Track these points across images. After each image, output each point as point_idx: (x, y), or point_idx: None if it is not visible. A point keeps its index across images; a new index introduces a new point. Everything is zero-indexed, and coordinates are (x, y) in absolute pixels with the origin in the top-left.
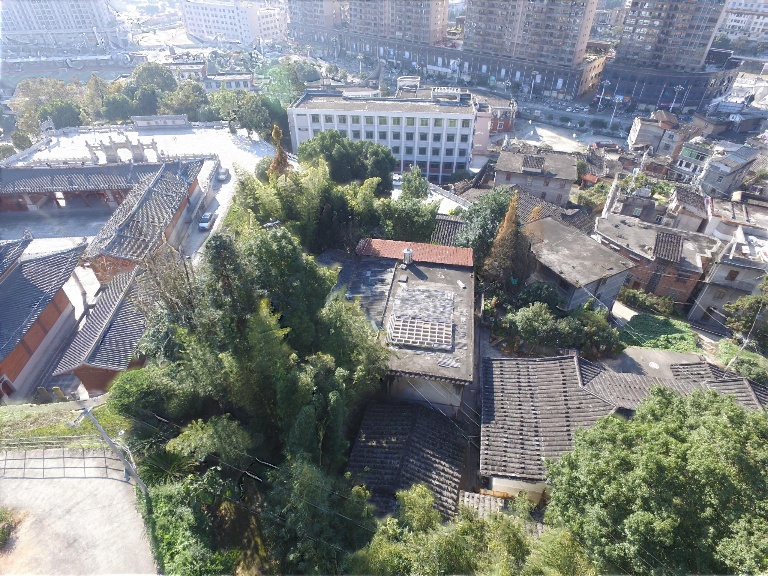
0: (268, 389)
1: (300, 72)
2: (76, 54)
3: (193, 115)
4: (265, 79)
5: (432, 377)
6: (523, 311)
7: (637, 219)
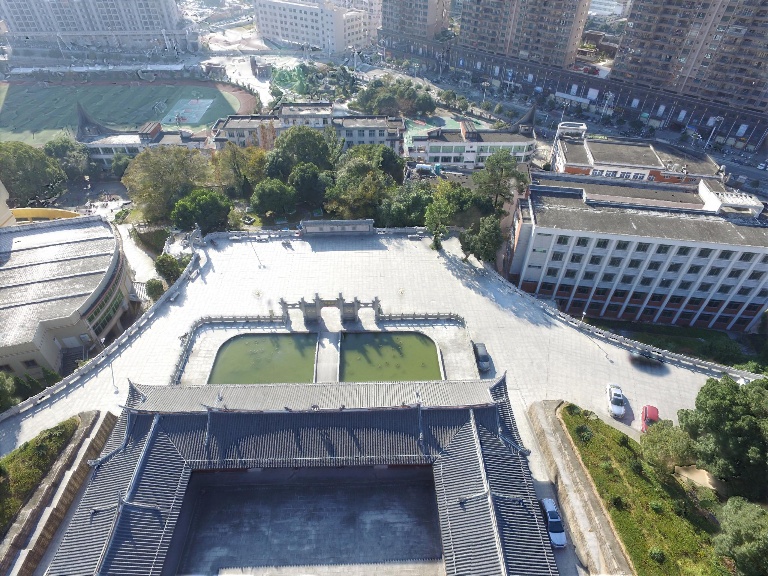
0: None
1: (413, 99)
2: (145, 62)
3: (373, 213)
4: (396, 121)
5: None
6: None
7: None
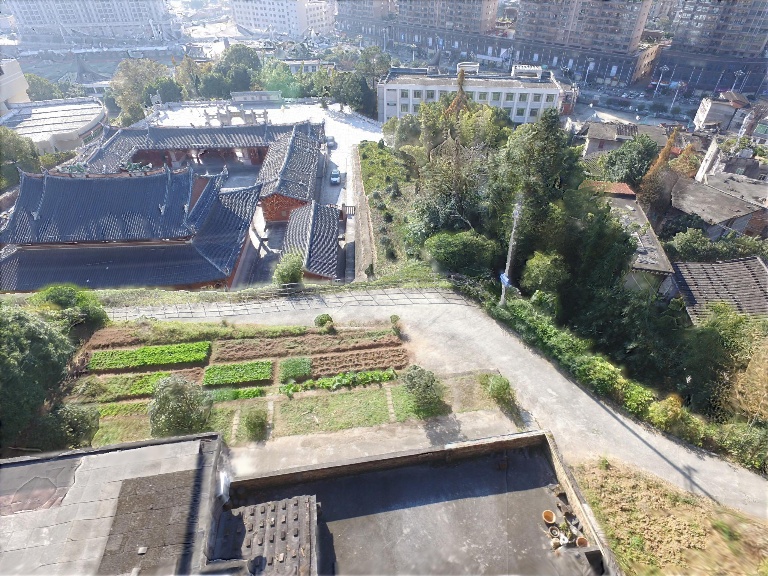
0: (569, 240)
1: (355, 61)
2: (135, 45)
3: (284, 92)
4: (329, 65)
5: (638, 269)
6: (681, 234)
7: (744, 176)
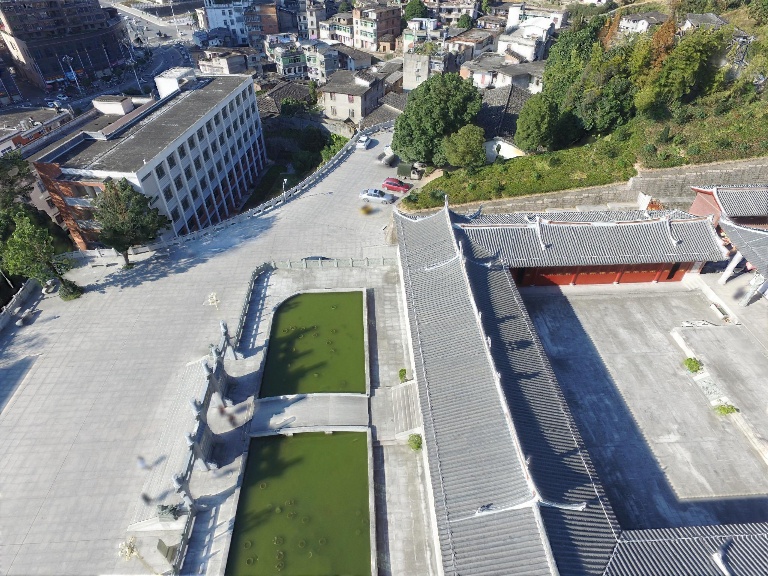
0: None
1: None
2: None
3: None
4: None
5: None
6: None
7: (468, 61)
